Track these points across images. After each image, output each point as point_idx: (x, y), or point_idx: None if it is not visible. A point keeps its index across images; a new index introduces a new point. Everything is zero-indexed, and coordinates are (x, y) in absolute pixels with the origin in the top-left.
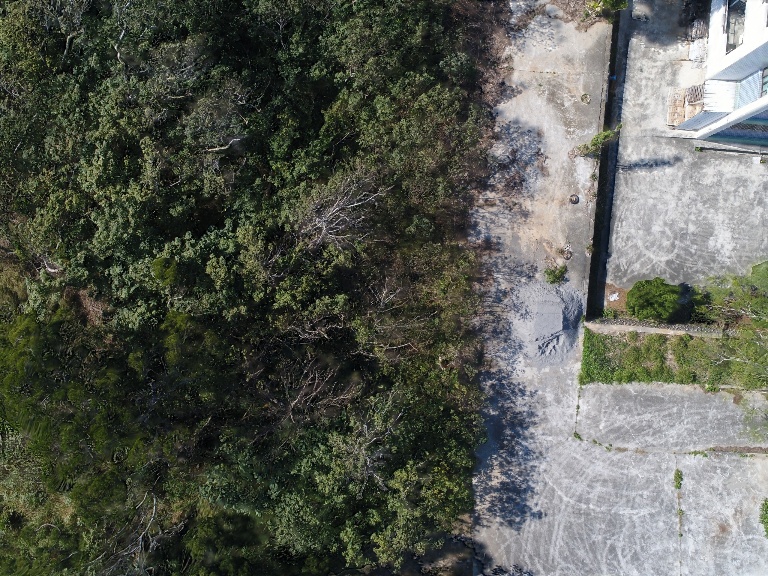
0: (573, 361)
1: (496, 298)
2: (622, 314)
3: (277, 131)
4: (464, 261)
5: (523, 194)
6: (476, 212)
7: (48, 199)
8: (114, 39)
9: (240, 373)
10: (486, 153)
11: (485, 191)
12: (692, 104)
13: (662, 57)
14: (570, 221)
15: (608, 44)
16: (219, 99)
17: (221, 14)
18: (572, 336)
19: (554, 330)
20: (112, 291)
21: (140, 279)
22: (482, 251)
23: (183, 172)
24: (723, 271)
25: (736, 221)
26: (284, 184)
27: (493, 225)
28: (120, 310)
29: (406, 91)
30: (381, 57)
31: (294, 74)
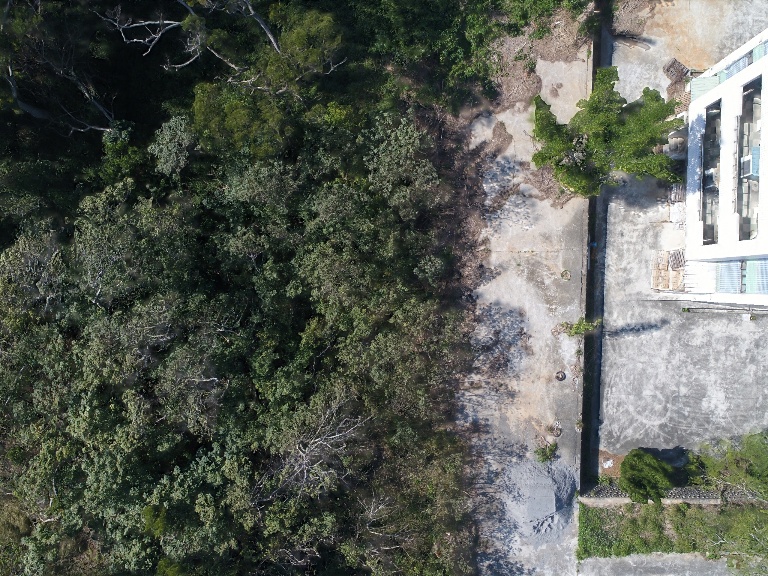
0: (569, 537)
1: (488, 479)
2: (618, 479)
3: (258, 349)
4: (450, 466)
5: (508, 374)
6: (462, 395)
7: (40, 446)
8: (91, 296)
9: (239, 574)
10: (469, 336)
11: (470, 374)
12: (675, 269)
13: (642, 220)
14: (558, 398)
15: (585, 218)
16: (196, 343)
17: (195, 246)
18: (567, 513)
19: (547, 512)
20: (107, 533)
21: (132, 525)
22: (471, 434)
23: (167, 413)
24: (718, 432)
25: (729, 381)
26: (267, 408)
27: (480, 407)
28: (116, 546)
29: (381, 308)
30: (354, 278)
31: (270, 297)
